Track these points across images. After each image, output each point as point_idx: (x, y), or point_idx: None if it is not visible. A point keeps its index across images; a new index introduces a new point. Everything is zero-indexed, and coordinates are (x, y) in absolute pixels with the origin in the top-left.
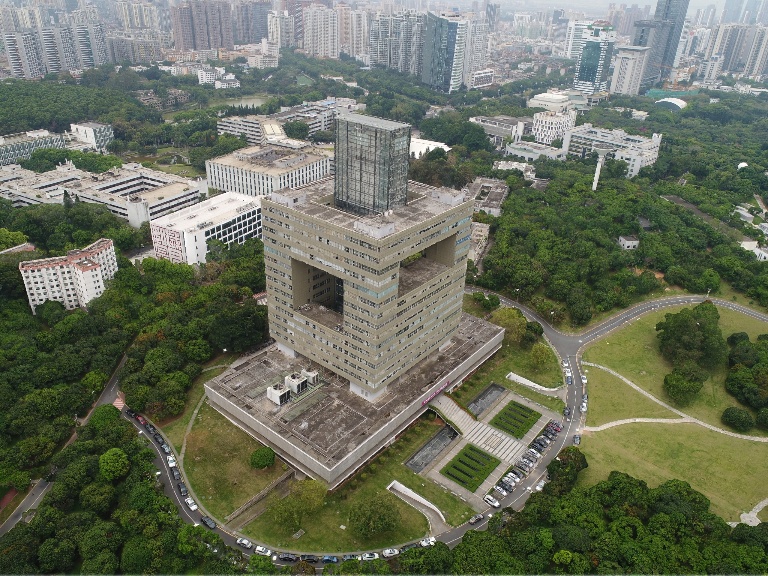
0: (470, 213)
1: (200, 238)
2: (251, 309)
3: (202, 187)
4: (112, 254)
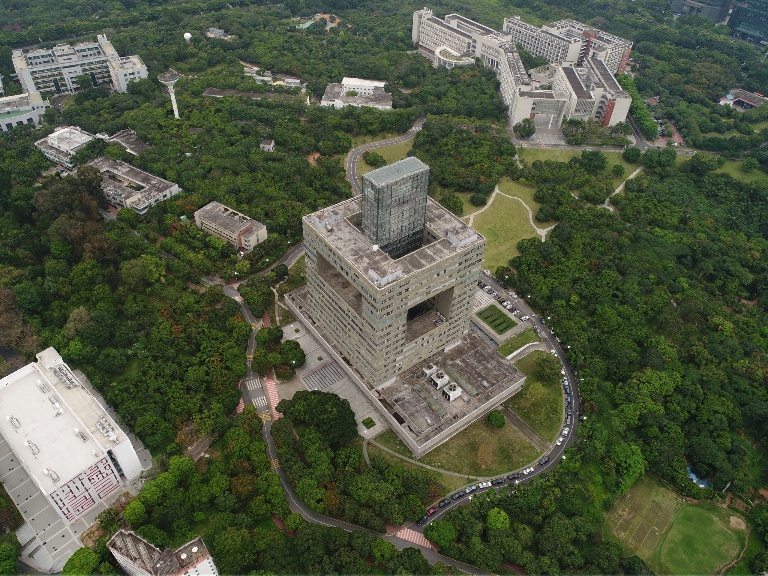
0: None
1: None
2: (328, 396)
3: None
4: None
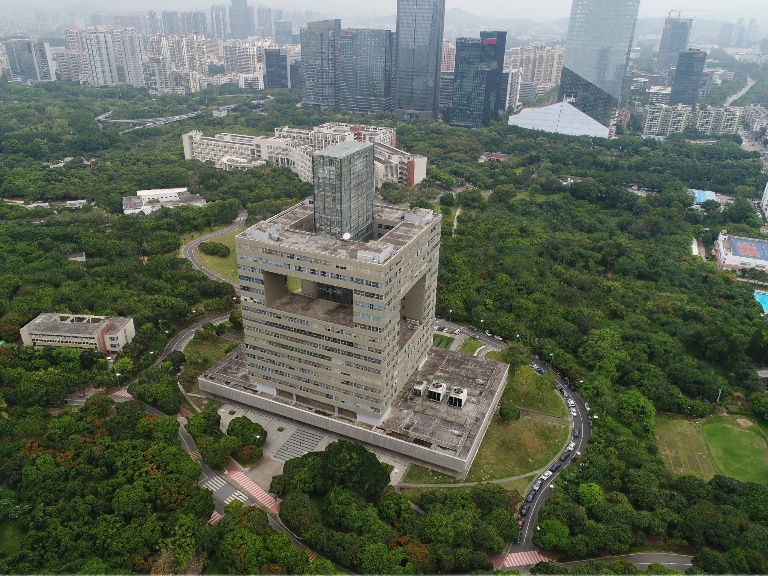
0: None
1: None
2: (336, 444)
3: None
4: None
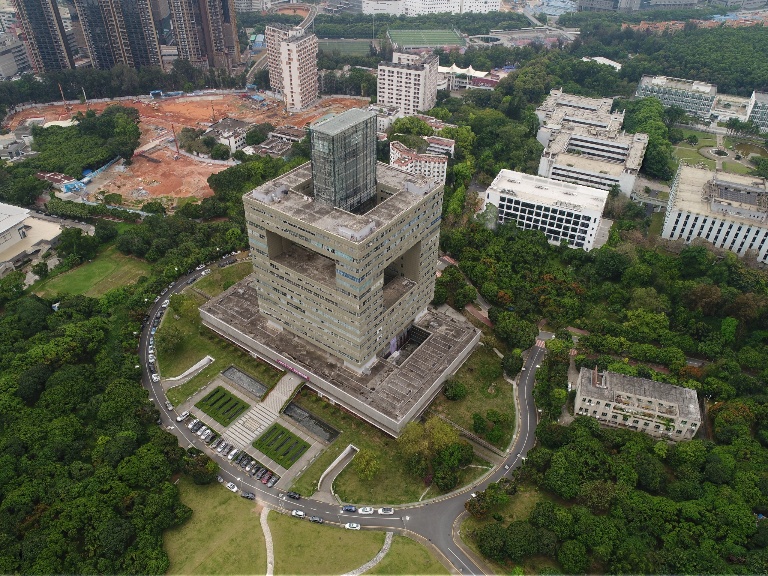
0: (353, 255)
1: (494, 198)
2: None
3: (626, 180)
4: (440, 169)
